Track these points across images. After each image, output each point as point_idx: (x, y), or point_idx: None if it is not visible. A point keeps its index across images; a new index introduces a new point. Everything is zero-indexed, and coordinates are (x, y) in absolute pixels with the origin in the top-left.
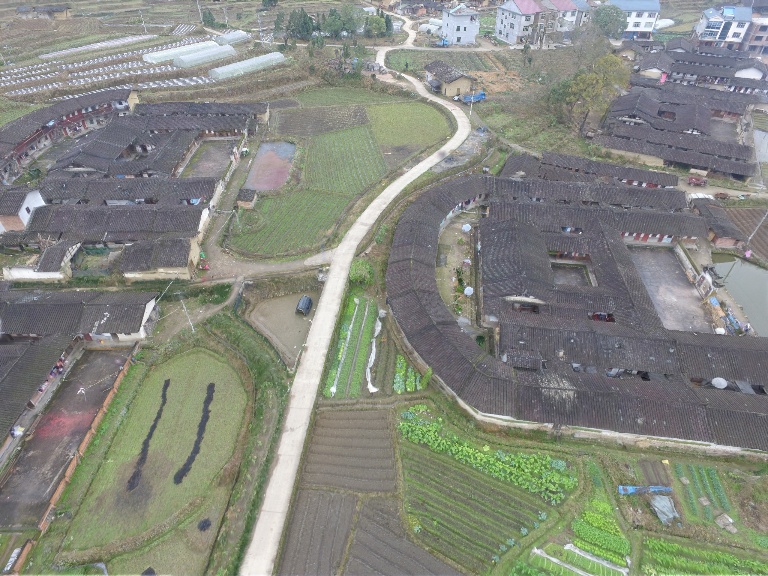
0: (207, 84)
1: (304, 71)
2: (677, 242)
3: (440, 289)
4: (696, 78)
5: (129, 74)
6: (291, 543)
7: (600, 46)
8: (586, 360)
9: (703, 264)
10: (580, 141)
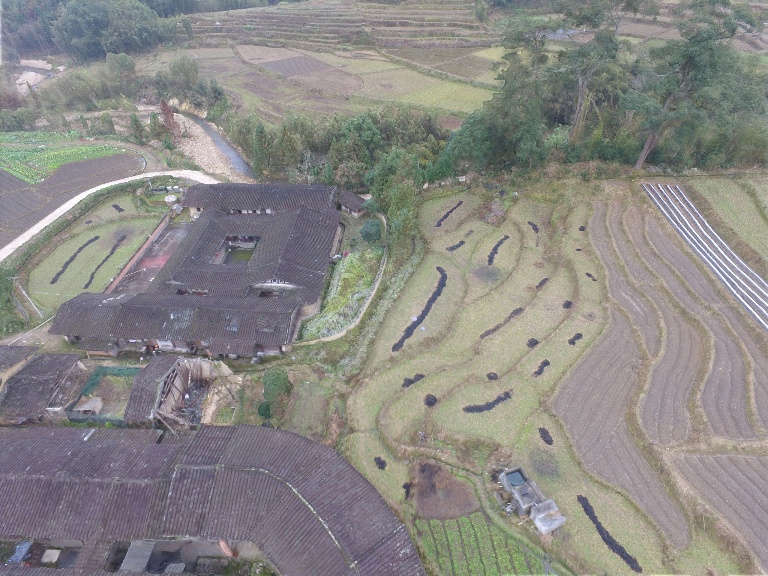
0: None
1: None
2: None
3: None
4: None
5: None
6: None
7: None
8: None
9: None
10: None
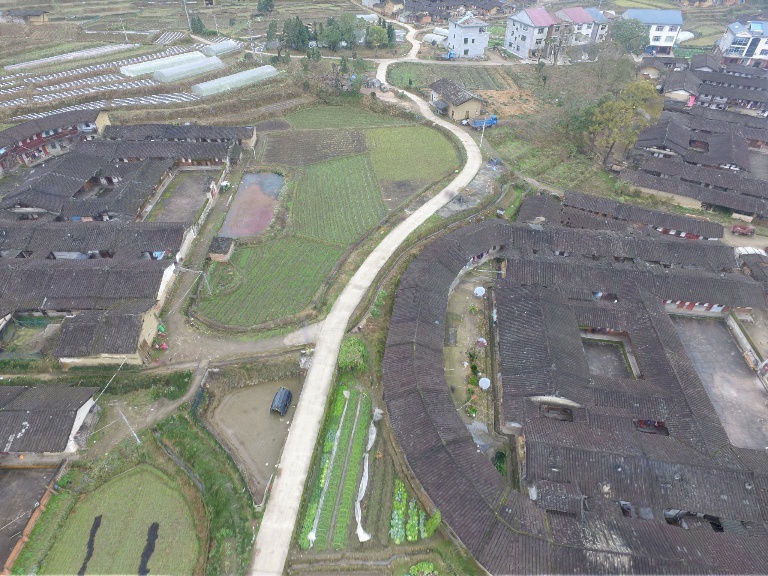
0: (189, 102)
1: (297, 87)
2: (729, 313)
3: (449, 379)
4: (726, 101)
5: (103, 89)
6: None
7: (624, 66)
8: (638, 498)
9: (762, 342)
10: (604, 175)
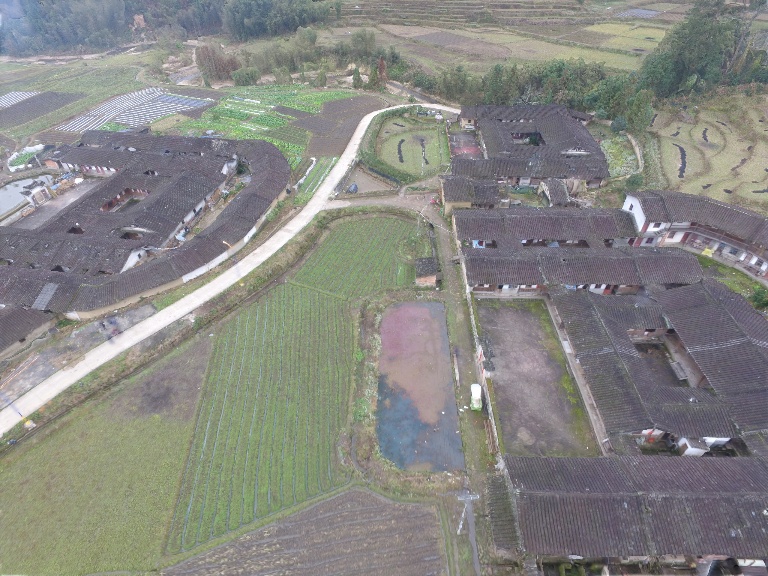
0: None
1: None
2: None
3: None
4: None
5: None
6: (354, 130)
7: None
8: None
9: None
10: None
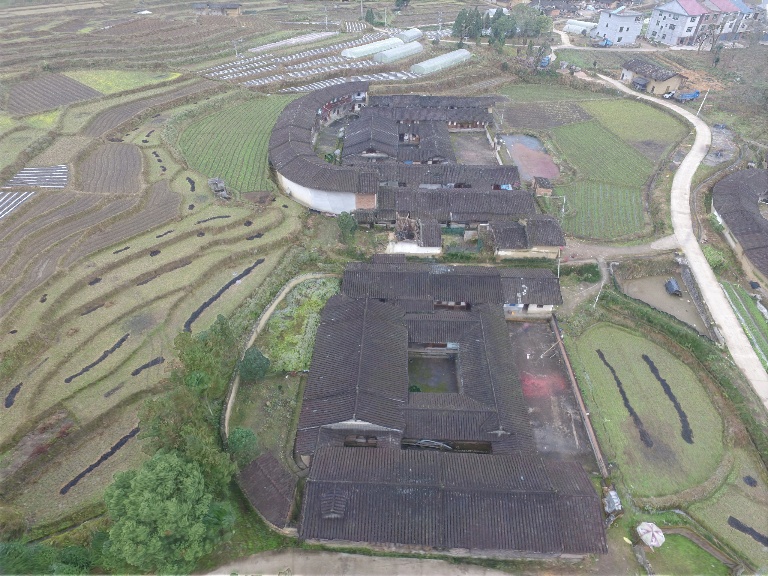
0: (416, 79)
1: (496, 68)
2: None
3: None
4: None
5: (339, 68)
6: None
7: None
8: None
9: None
10: None
